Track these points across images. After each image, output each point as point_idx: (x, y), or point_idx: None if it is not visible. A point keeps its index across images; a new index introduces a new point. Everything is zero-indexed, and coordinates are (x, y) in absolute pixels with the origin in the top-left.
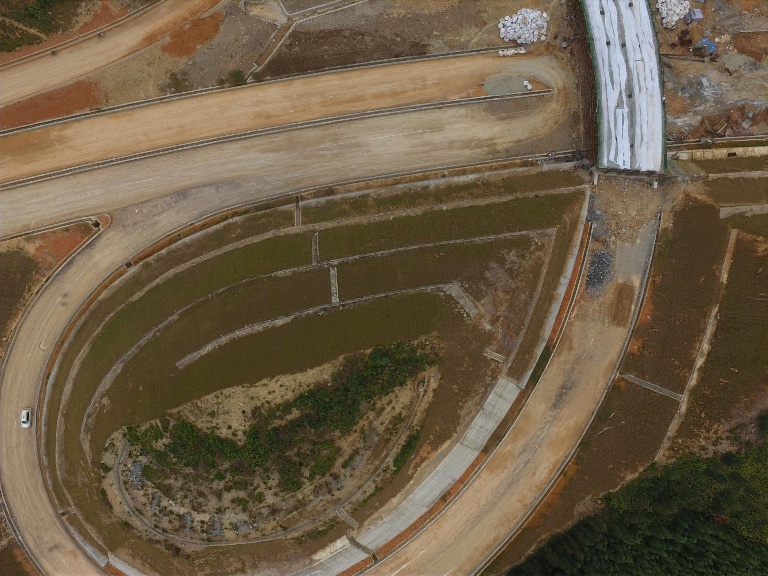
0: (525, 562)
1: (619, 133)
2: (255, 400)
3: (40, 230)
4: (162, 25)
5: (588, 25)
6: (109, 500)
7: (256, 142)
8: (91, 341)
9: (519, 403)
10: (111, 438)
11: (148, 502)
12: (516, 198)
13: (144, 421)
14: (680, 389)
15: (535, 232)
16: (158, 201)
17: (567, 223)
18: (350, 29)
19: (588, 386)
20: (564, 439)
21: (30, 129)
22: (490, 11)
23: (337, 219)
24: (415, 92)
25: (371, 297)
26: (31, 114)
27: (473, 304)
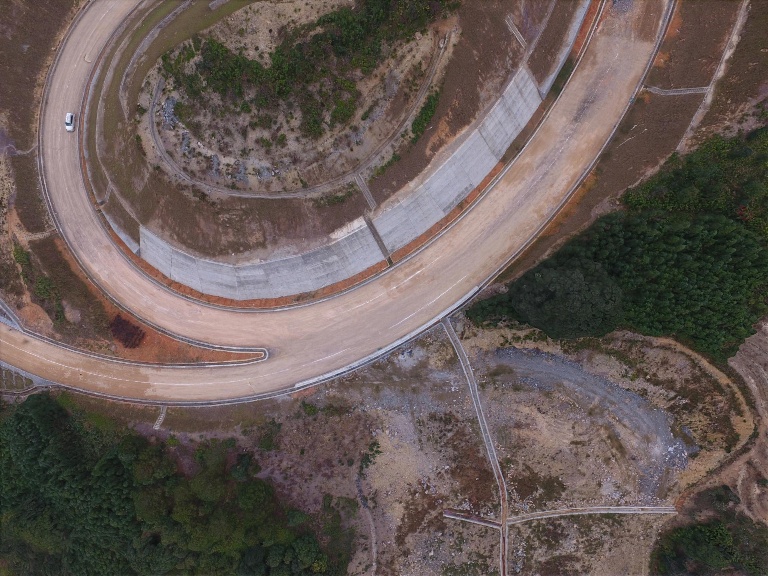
0: None
1: None
2: (282, 18)
3: None
4: None
5: None
6: (143, 147)
7: None
8: (131, 34)
9: (540, 114)
10: (147, 76)
11: (178, 143)
12: None
13: (178, 43)
14: (706, 82)
15: None
16: None
17: None
18: None
19: (611, 100)
20: (584, 152)
21: None
22: None
23: None
24: None
25: None
26: None
27: None
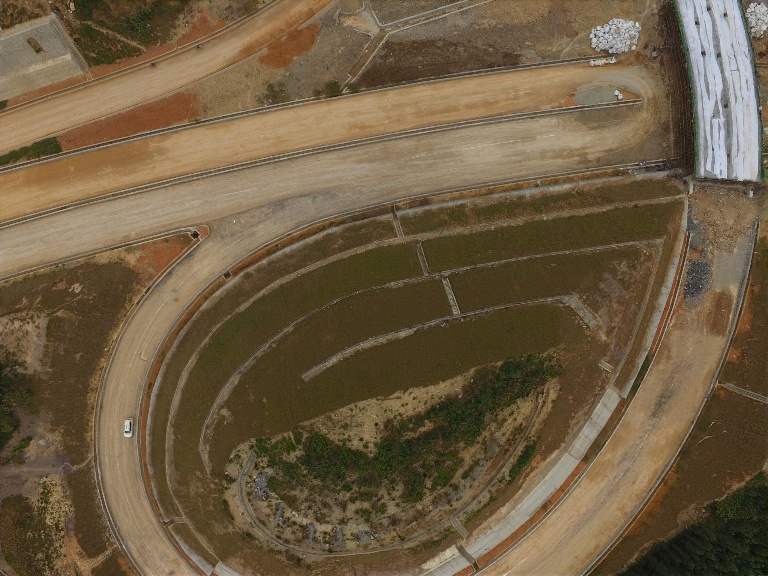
0: (628, 571)
1: (715, 143)
2: (388, 412)
3: (140, 241)
4: (259, 37)
5: (683, 35)
6: (230, 511)
7: (351, 153)
8: (198, 352)
9: (619, 412)
10: (237, 450)
11: (272, 513)
12: (615, 208)
13: (276, 433)
14: None
15: (643, 243)
16: (255, 212)
17: (671, 233)
18: (443, 40)
19: (687, 395)
20: (664, 448)
21: (130, 141)
22: (580, 21)
23: (439, 230)
24: (507, 102)
25: (492, 309)
26: (131, 126)
27: (592, 315)
